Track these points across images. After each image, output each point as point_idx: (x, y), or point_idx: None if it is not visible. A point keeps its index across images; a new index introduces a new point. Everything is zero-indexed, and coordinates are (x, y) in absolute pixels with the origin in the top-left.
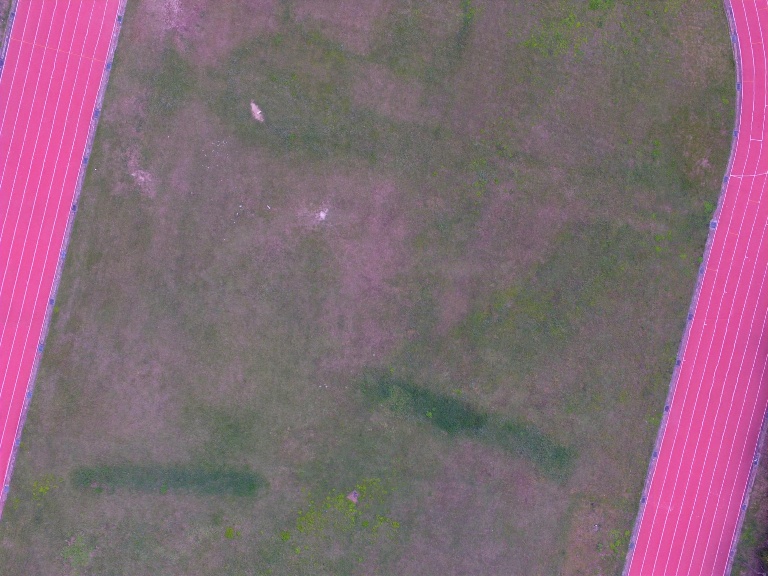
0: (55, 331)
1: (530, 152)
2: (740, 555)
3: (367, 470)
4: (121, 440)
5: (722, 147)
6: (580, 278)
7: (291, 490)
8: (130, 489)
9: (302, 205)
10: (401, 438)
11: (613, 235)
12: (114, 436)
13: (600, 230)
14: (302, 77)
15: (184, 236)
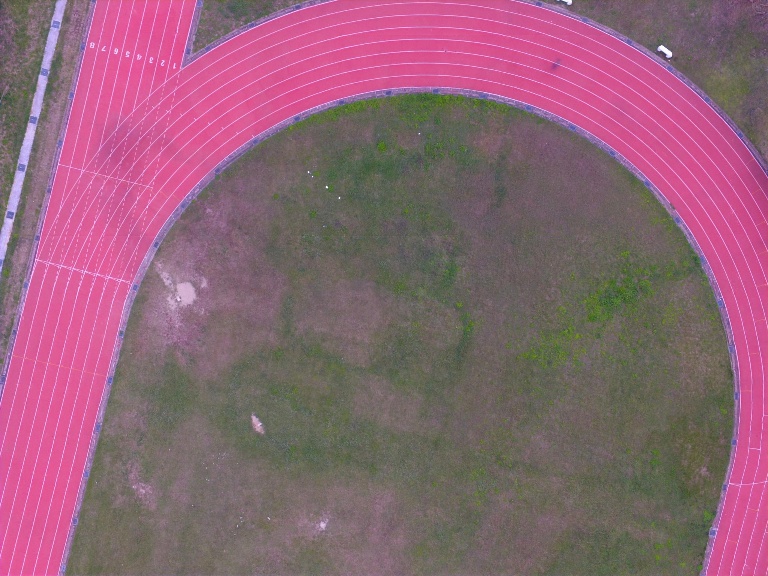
0: None
1: (530, 462)
2: None
3: None
4: None
5: (721, 456)
6: None
7: None
8: None
9: (302, 516)
10: None
11: (613, 543)
12: None
13: (600, 539)
14: (303, 390)
15: (184, 548)
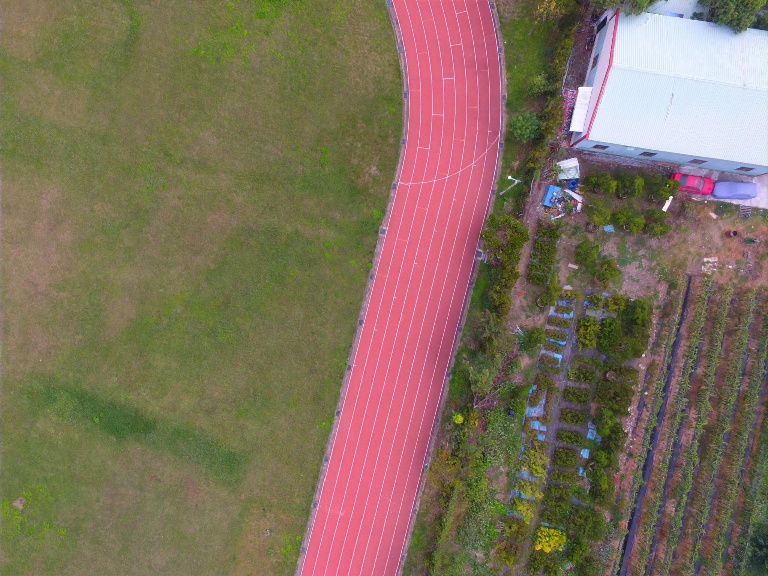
0: None
1: (198, 158)
2: (410, 559)
3: (33, 476)
4: None
5: (390, 155)
6: (249, 284)
7: None
8: None
9: None
10: (68, 444)
11: (282, 241)
12: None
13: (269, 236)
14: None
15: None
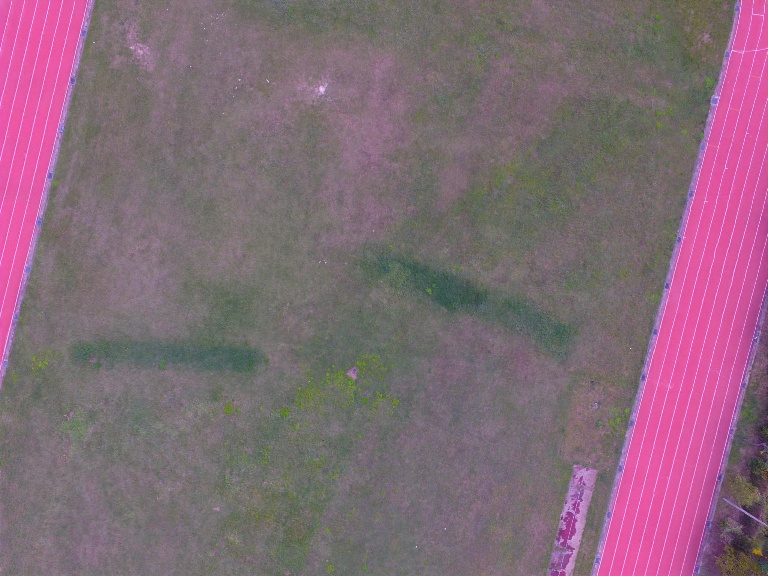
0: (54, 205)
1: (530, 26)
2: (740, 432)
3: (367, 347)
4: (120, 315)
5: (723, 22)
6: (580, 154)
7: (290, 366)
8: (129, 364)
9: (301, 79)
10: (401, 315)
11: (614, 111)
12: (113, 311)
13: (601, 105)
14: None
15: (183, 110)
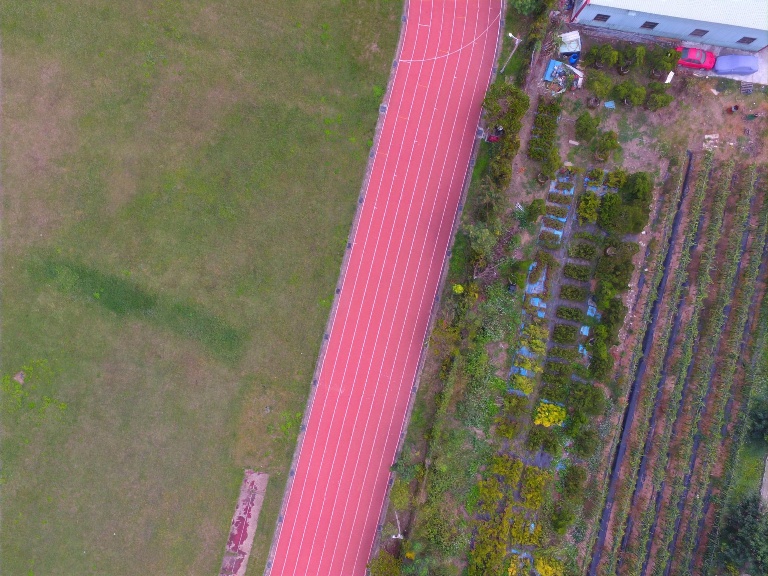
0: None
1: (199, 34)
2: (409, 437)
3: (34, 351)
4: None
5: (390, 32)
6: (250, 160)
7: None
8: None
9: None
10: (69, 319)
11: (283, 118)
12: None
13: (269, 112)
14: None
15: None
